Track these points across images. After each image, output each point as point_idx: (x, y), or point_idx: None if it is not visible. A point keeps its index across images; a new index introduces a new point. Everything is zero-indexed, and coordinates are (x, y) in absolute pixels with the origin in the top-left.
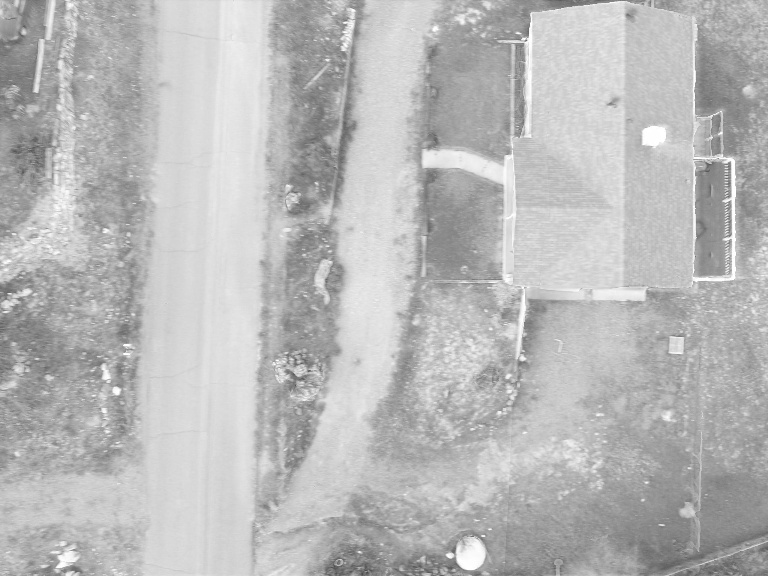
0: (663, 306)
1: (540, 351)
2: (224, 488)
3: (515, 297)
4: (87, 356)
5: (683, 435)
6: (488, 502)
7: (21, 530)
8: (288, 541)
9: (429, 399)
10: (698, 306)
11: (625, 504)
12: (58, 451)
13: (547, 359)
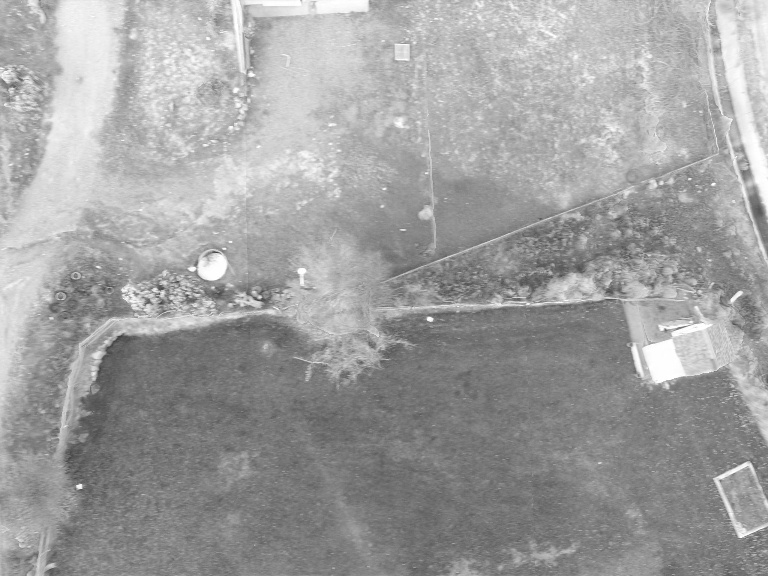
0: (387, 15)
1: (269, 67)
2: None
3: (225, 1)
4: None
5: (418, 141)
6: (226, 215)
7: None
8: (22, 255)
9: (156, 114)
10: (422, 14)
11: (364, 210)
12: None
13: (276, 74)
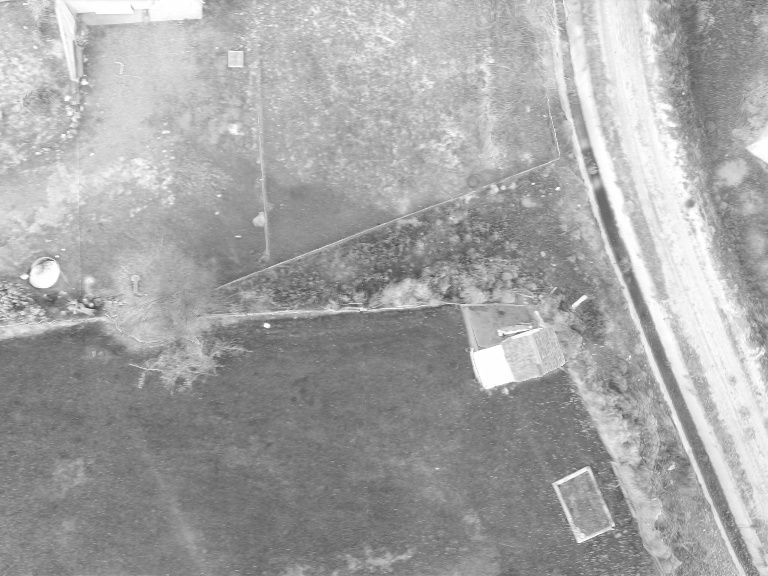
0: (220, 22)
1: (102, 75)
2: None
3: (49, 10)
4: None
5: (253, 148)
6: (59, 223)
7: None
8: None
9: None
10: (257, 21)
11: (198, 217)
12: None
13: (109, 82)
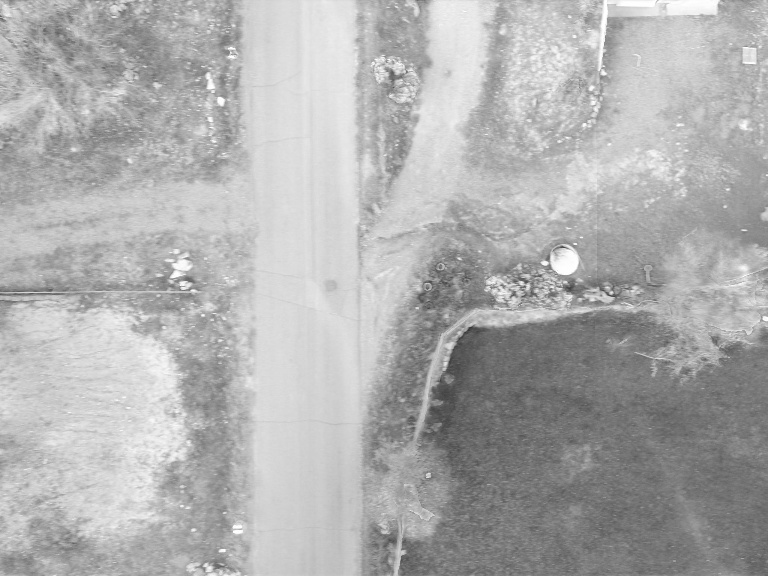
0: (735, 19)
1: (620, 66)
2: (329, 193)
3: (597, 0)
4: (192, 66)
5: (760, 143)
6: (578, 211)
7: (137, 236)
8: (392, 245)
9: (518, 109)
10: (767, 19)
11: (708, 210)
12: (168, 159)
13: (627, 74)
